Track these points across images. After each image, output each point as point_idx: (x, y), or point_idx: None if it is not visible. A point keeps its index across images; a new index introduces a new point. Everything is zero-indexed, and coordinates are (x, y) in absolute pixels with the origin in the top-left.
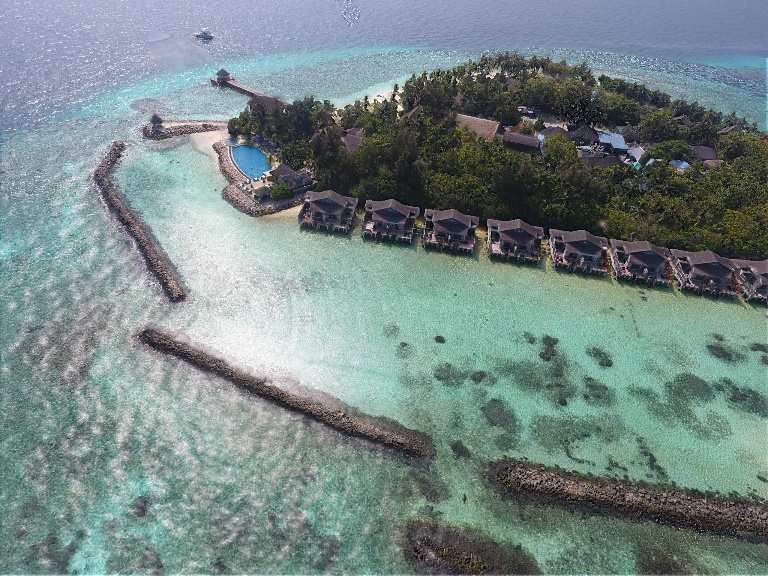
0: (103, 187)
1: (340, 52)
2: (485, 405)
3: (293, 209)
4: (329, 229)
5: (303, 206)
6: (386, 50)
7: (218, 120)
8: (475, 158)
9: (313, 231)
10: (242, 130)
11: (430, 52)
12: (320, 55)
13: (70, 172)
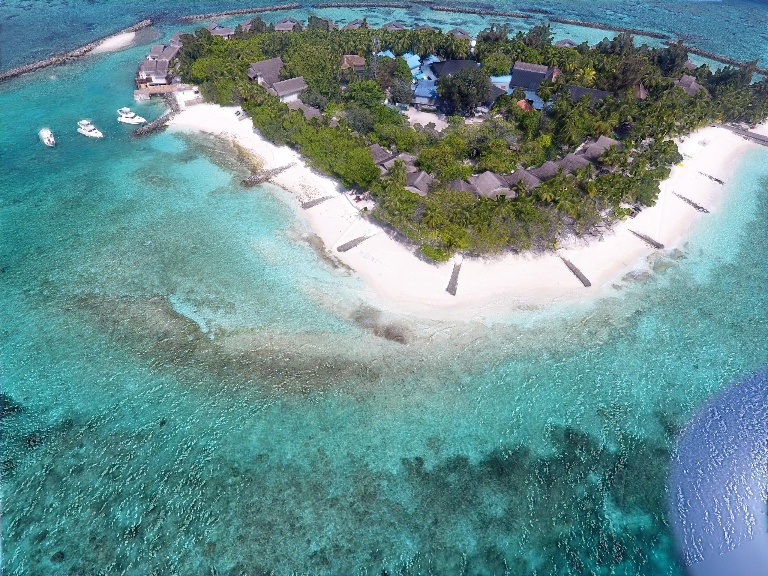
0: None
1: None
2: (534, 24)
3: None
4: None
5: None
6: None
7: None
8: None
9: None
10: None
11: None
12: None
13: None
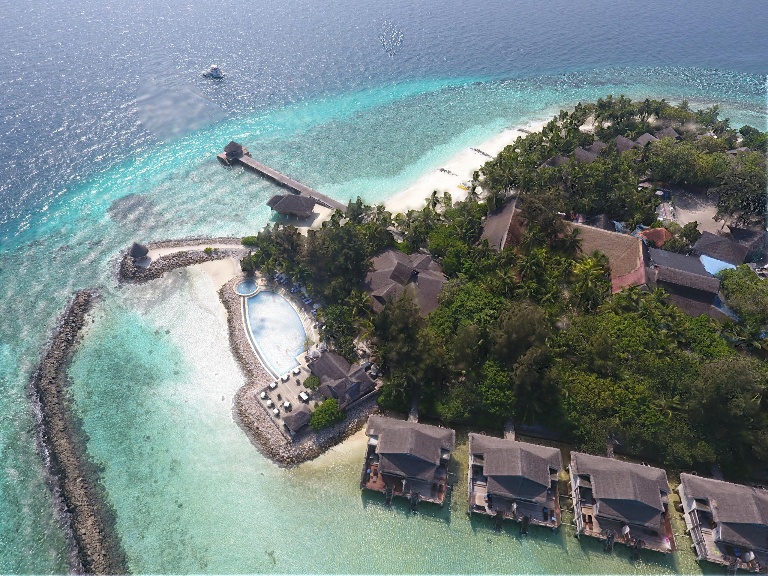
0: (46, 410)
1: (380, 91)
2: None
3: (347, 443)
4: (412, 502)
5: (366, 455)
6: (437, 85)
7: (227, 233)
8: (636, 338)
9: (385, 505)
10: (261, 270)
11: (493, 85)
12: (356, 99)
13: (3, 367)
